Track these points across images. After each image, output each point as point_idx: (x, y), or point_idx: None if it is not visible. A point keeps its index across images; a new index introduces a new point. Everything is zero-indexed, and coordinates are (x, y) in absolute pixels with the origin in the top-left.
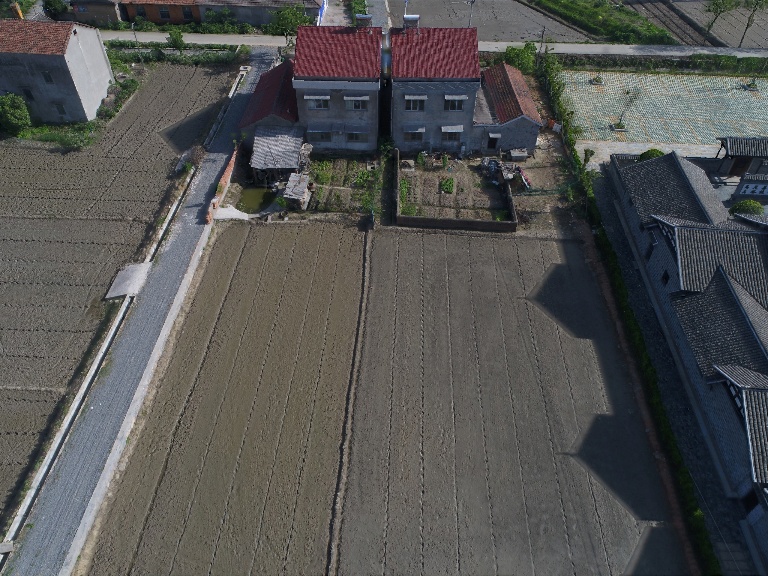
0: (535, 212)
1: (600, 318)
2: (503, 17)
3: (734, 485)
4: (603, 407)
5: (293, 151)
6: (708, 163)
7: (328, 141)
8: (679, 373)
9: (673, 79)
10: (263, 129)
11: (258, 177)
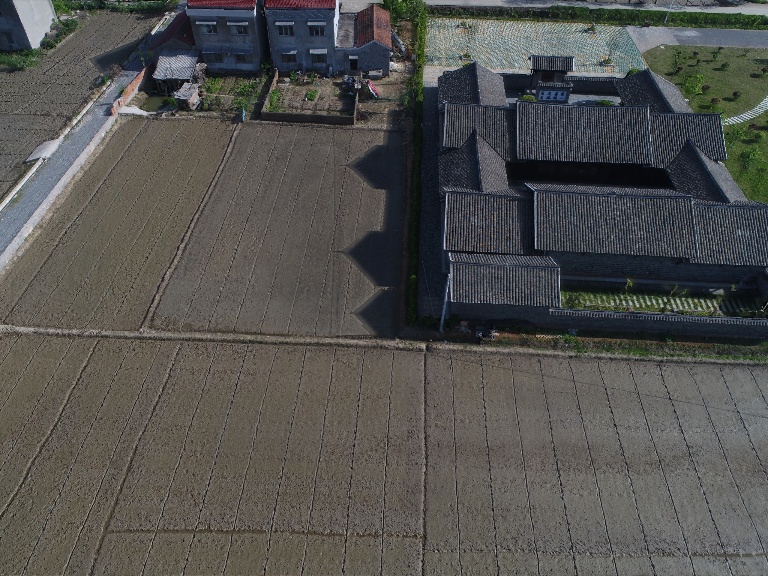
0: (375, 113)
1: (398, 178)
2: None
3: (447, 265)
4: (378, 227)
5: (189, 67)
6: (521, 78)
7: (221, 62)
8: (440, 208)
9: (529, 24)
10: (167, 51)
11: (161, 87)
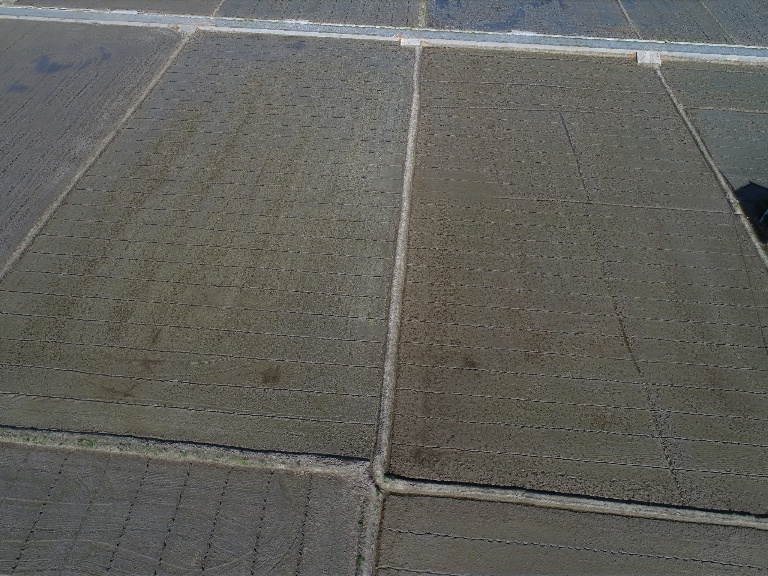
0: None
1: None
2: None
3: None
4: None
5: None
6: None
7: None
8: None
9: None
10: None
11: None
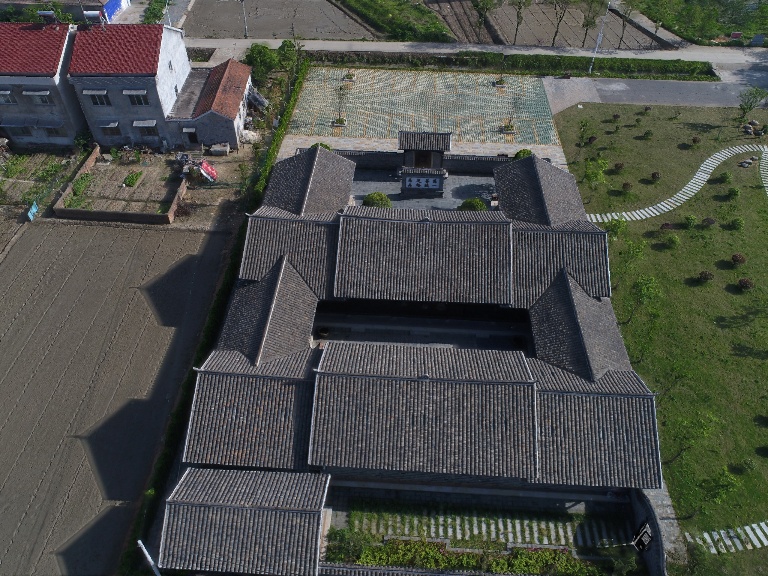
0: (203, 205)
1: (199, 307)
2: (302, 15)
3: None
4: (144, 392)
5: None
6: (390, 157)
7: (30, 135)
8: None
9: (428, 76)
10: None
11: None
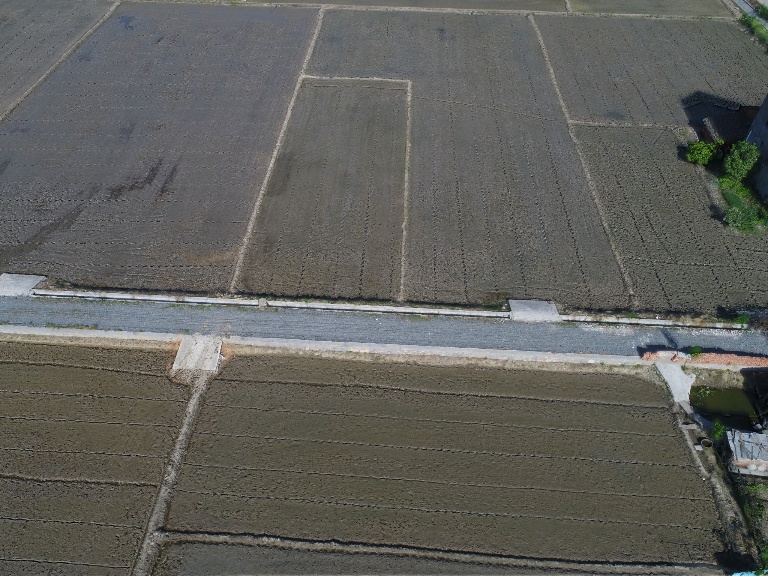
0: None
1: None
2: None
3: None
4: None
5: None
6: None
7: None
8: None
9: None
10: None
11: None
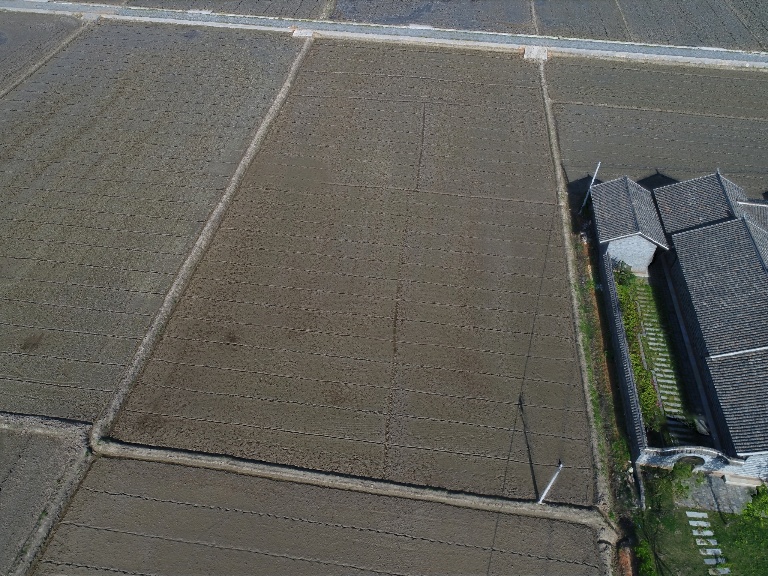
0: None
1: None
2: None
3: None
4: None
5: None
6: None
7: None
8: None
9: None
10: None
11: None
